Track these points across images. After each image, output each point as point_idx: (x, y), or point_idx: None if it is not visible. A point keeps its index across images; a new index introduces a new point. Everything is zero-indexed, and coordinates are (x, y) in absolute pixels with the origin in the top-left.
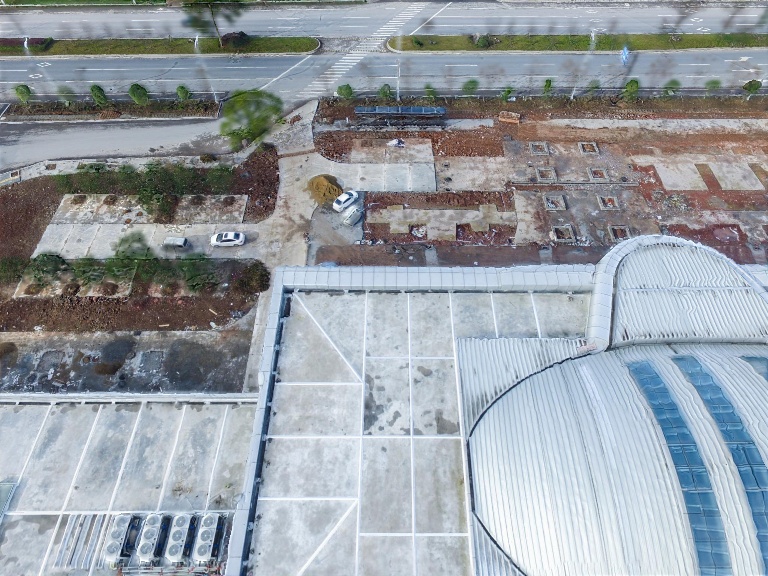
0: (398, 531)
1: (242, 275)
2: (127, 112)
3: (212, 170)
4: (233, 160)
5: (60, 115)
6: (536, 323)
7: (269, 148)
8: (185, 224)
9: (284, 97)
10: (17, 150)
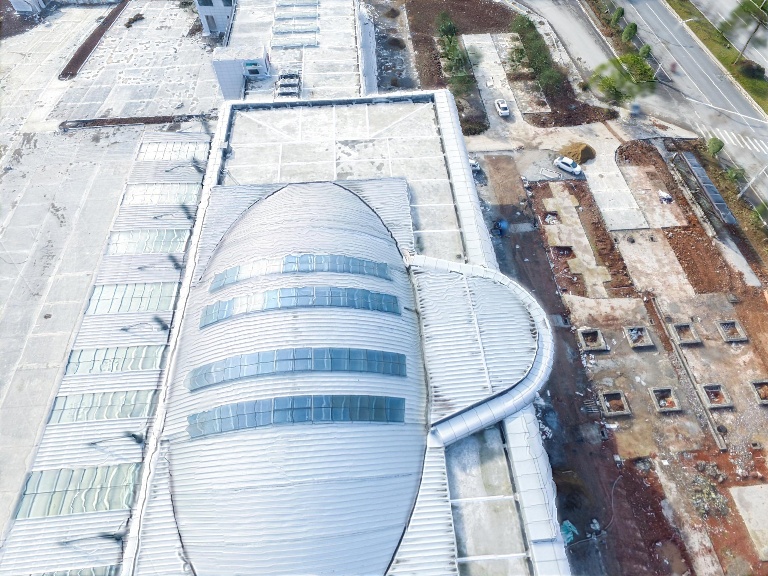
0: (282, 160)
1: (474, 121)
2: (615, 39)
3: (571, 90)
4: (588, 99)
5: (594, 12)
6: (429, 230)
7: (612, 115)
8: (511, 87)
9: (688, 115)
10: (551, 7)
